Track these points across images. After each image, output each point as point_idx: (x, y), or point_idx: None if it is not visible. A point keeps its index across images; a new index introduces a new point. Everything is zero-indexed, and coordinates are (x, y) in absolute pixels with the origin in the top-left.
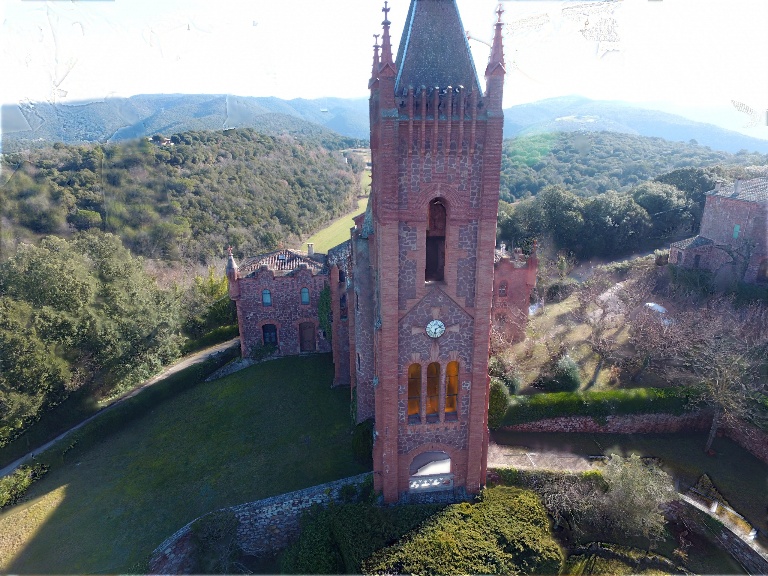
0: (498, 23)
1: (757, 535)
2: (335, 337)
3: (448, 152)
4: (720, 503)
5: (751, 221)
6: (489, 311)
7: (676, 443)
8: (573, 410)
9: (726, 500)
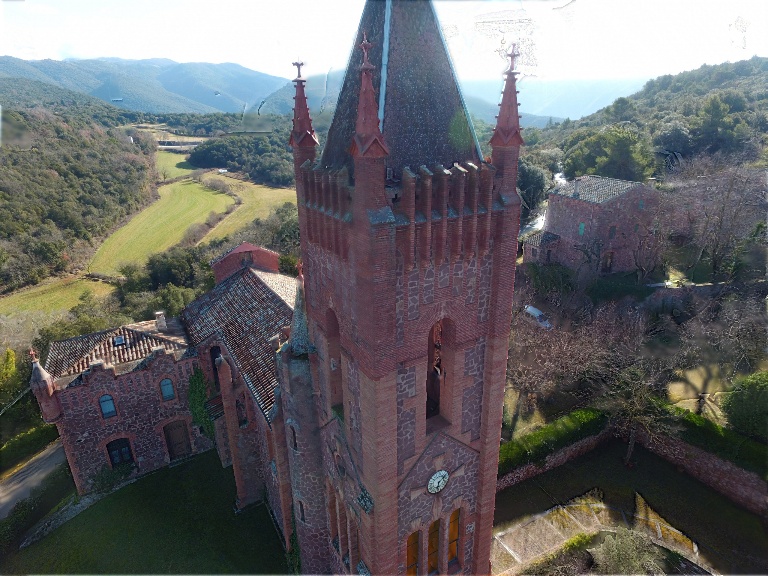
0: (513, 72)
1: (699, 549)
2: (234, 451)
3: (457, 259)
4: (660, 523)
5: (595, 220)
6: (498, 440)
7: (601, 463)
8: (517, 462)
9: (662, 517)
